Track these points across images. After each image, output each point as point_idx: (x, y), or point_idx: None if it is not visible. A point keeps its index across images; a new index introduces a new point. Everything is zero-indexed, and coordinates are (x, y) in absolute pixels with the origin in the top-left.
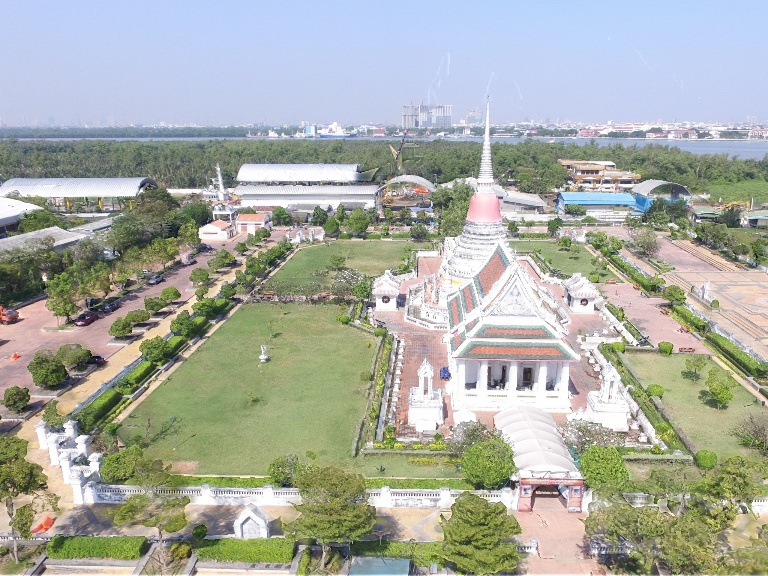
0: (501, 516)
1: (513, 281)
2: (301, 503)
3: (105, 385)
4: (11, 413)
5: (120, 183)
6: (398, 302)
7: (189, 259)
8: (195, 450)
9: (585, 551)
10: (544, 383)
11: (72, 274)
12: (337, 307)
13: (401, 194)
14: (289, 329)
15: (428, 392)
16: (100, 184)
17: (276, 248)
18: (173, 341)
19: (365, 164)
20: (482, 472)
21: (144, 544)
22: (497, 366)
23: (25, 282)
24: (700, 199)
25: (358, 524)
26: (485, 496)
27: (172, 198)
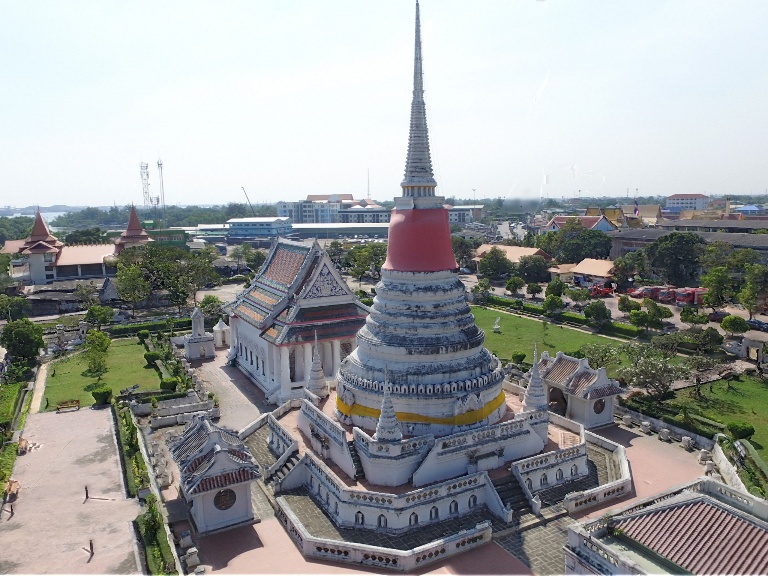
0: None
1: None
2: None
3: None
4: None
5: None
6: None
7: None
8: None
9: None
10: None
11: None
12: None
13: None
14: None
15: None
16: None
17: None
18: None
19: None
20: None
21: None
22: None
23: None
24: None
25: None
26: None
27: None
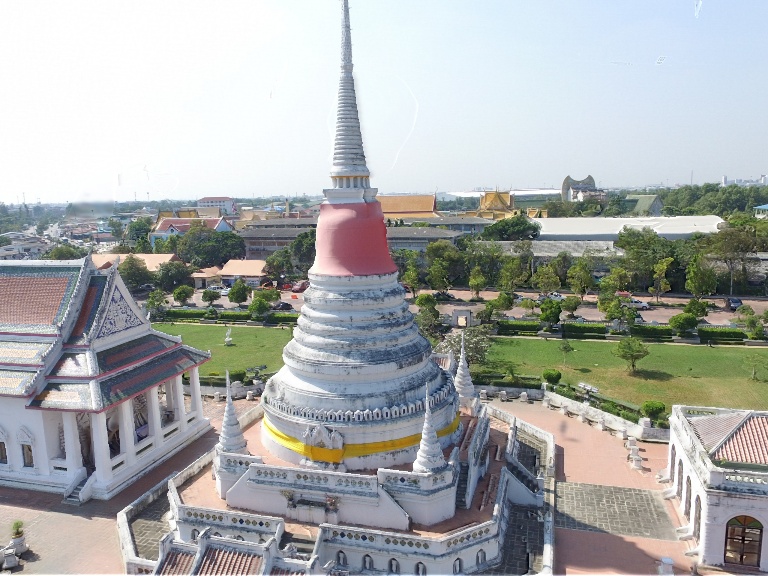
0: None
1: None
2: None
3: None
4: None
5: None
6: None
7: None
8: None
9: None
10: None
11: None
12: None
13: None
14: None
15: None
16: None
17: (680, 315)
18: None
19: None
20: None
21: None
22: None
23: None
24: None
25: None
26: None
27: None
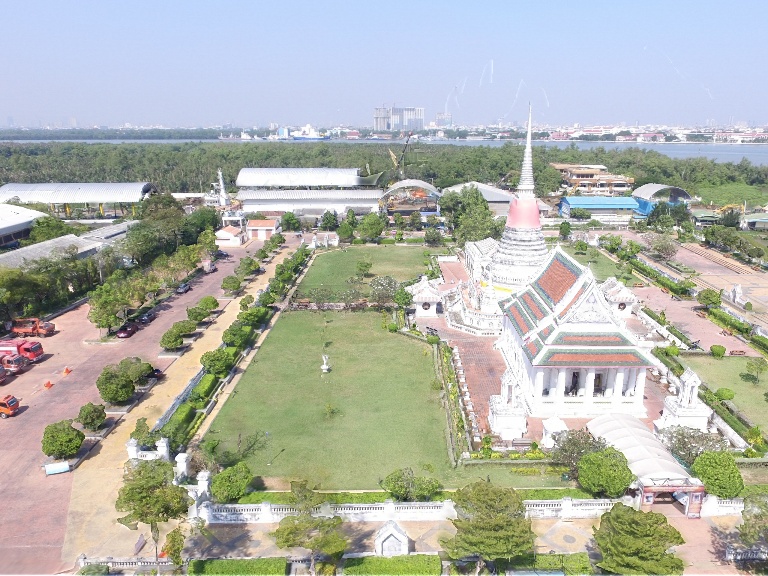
0: (662, 527)
1: (590, 289)
2: (422, 517)
3: (177, 400)
4: (87, 431)
5: (121, 188)
6: (436, 308)
7: (211, 266)
8: (291, 465)
9: (719, 557)
10: (621, 389)
11: (111, 284)
12: (378, 314)
13: (399, 198)
14: (338, 338)
15: (512, 400)
16: (101, 189)
17: (299, 254)
18: (229, 352)
19: (364, 168)
20: (606, 481)
21: (286, 565)
22: (567, 373)
23: (53, 293)
24: (697, 202)
25: (526, 539)
26: (606, 505)
27: (178, 204)
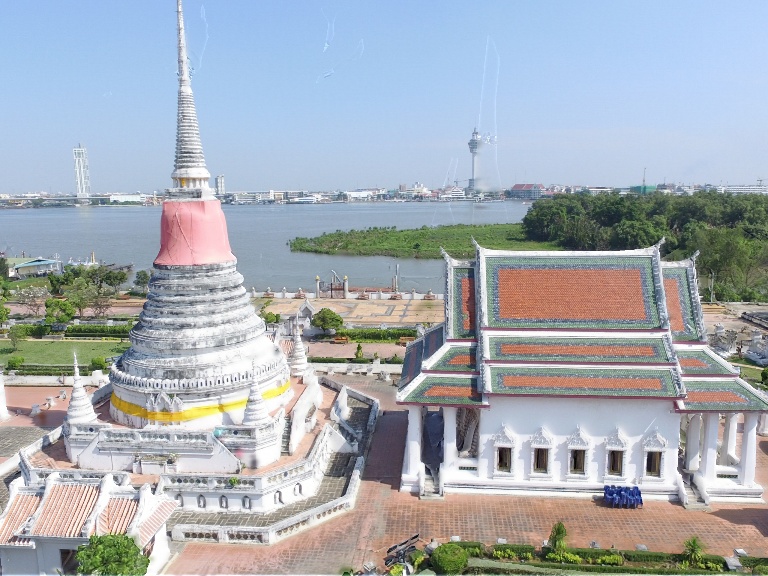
0: None
1: None
2: None
3: None
4: None
5: None
6: None
7: None
8: None
9: None
10: None
11: None
12: None
13: None
14: None
15: None
16: None
17: None
18: None
19: None
20: None
21: None
22: None
23: None
24: None
25: None
26: None
27: None
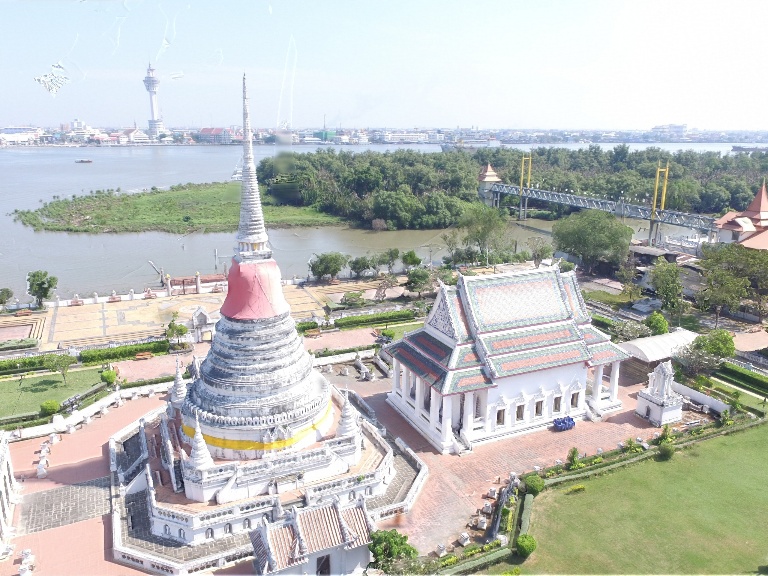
0: None
1: None
2: None
3: None
4: None
5: None
6: None
7: None
8: None
9: None
10: None
11: None
12: None
13: None
14: None
15: None
16: None
17: None
18: None
19: None
20: None
21: None
22: None
23: None
24: None
25: None
26: (725, 360)
27: None
